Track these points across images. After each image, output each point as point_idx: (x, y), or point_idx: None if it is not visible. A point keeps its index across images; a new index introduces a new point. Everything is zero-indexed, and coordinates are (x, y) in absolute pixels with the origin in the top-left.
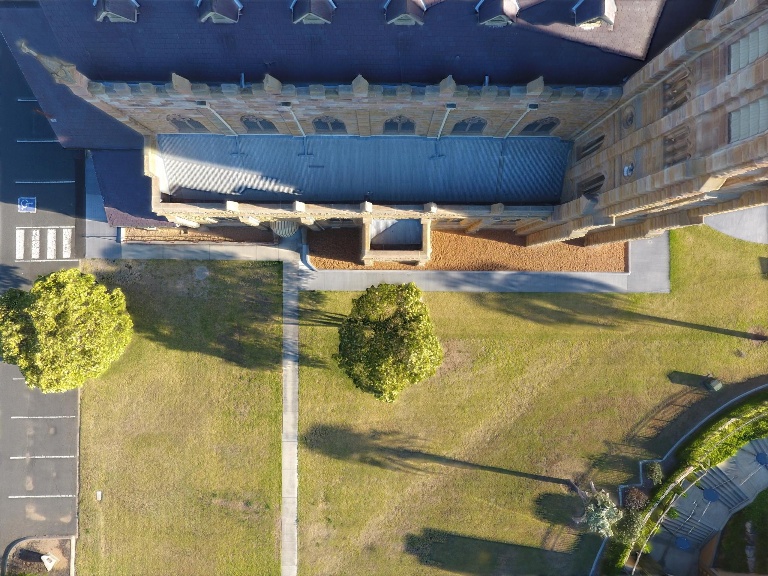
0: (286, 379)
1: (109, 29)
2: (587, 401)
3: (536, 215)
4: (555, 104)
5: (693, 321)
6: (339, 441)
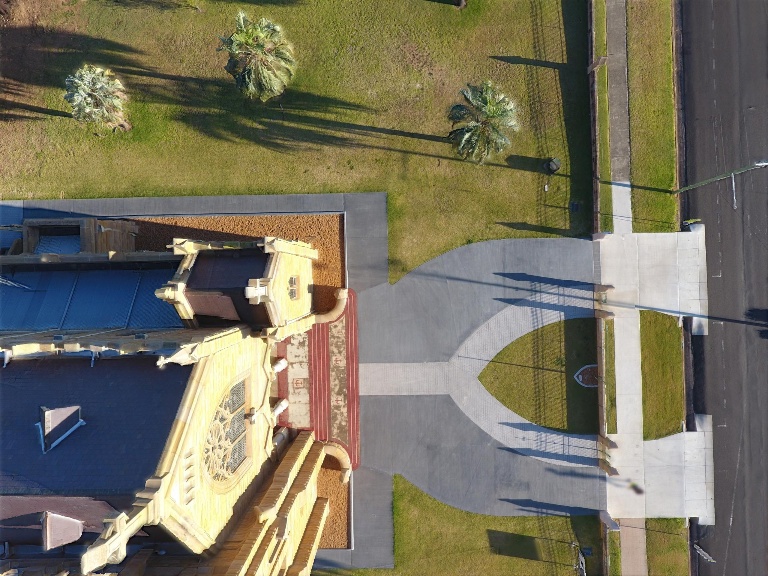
0: None
1: None
2: None
3: None
4: None
5: None
6: None
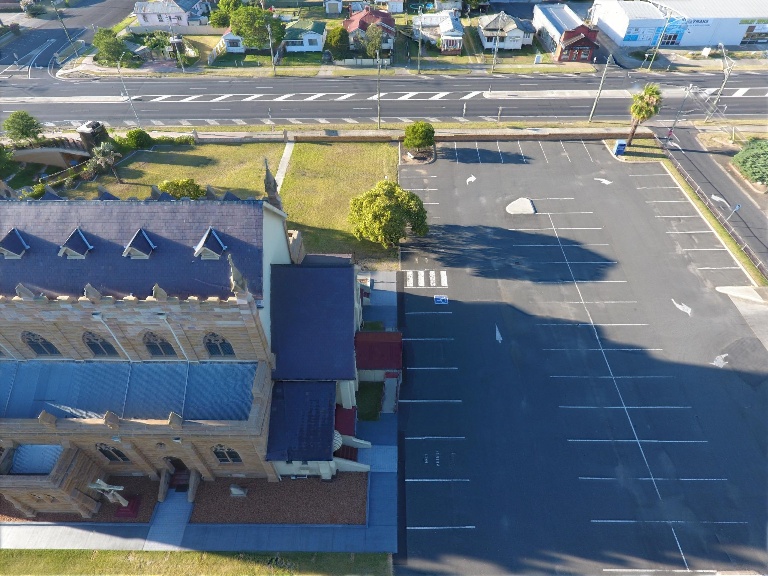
0: None
1: None
2: None
3: None
4: None
5: None
6: (245, 196)
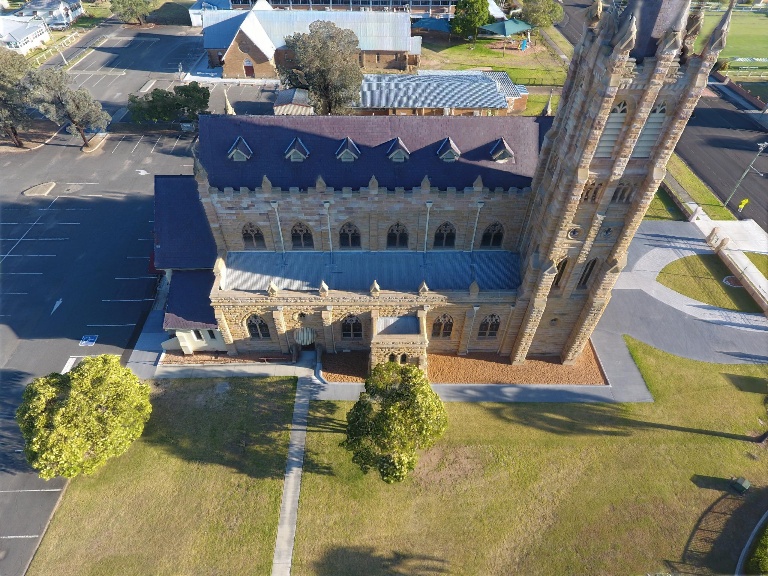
0: (287, 486)
1: (231, 165)
2: (616, 509)
3: (506, 300)
4: (494, 202)
5: (689, 426)
6: (340, 562)
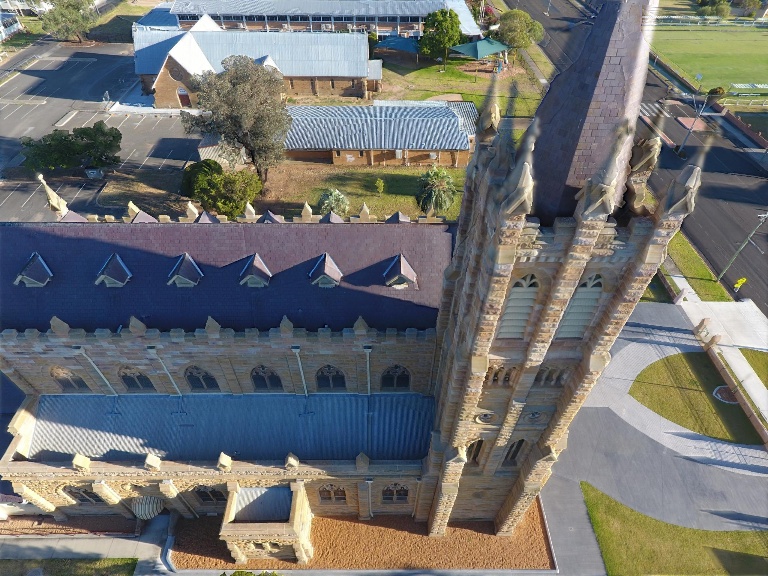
0: None
1: (23, 292)
2: None
3: (408, 472)
4: (387, 346)
5: None
6: None
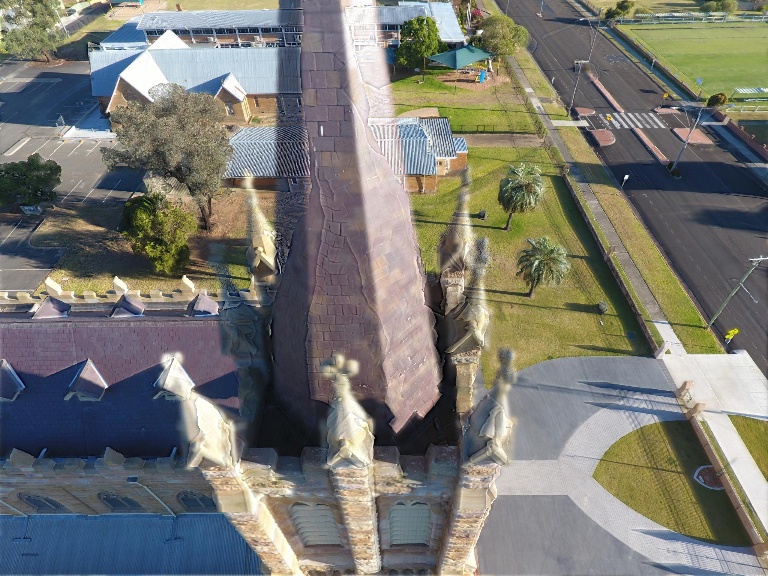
0: None
1: None
2: None
3: None
4: None
5: None
6: None
